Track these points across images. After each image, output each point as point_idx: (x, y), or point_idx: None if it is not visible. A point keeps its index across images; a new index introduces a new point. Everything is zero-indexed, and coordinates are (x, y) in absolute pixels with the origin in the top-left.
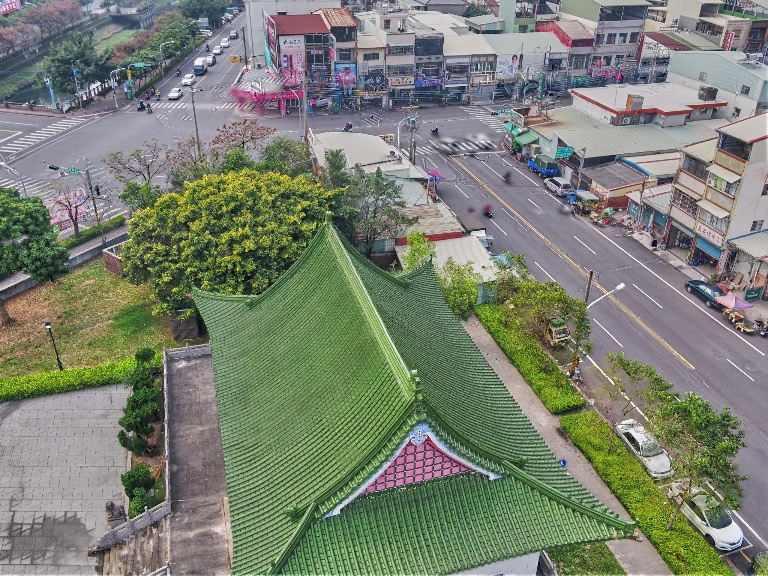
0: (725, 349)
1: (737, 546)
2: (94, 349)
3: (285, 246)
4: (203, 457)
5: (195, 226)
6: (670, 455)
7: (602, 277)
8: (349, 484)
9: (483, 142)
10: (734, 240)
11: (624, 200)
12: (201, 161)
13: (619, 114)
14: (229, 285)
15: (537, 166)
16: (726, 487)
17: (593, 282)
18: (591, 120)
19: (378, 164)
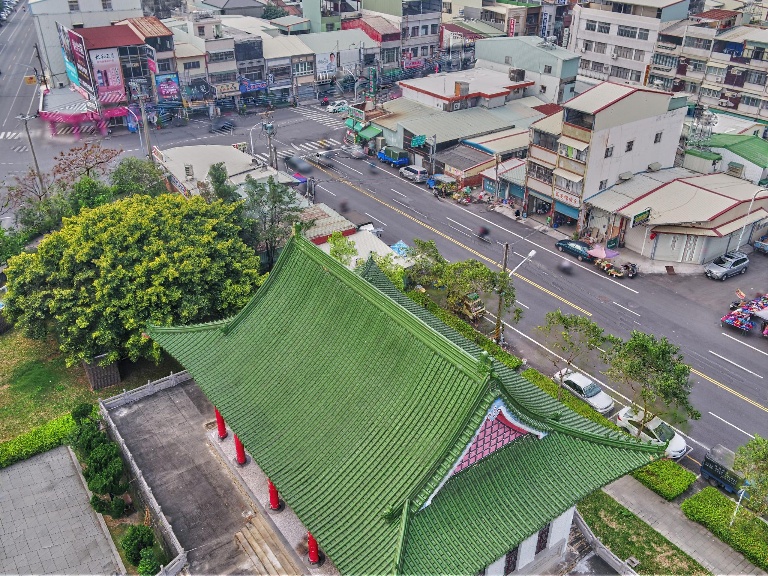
0: (608, 294)
1: (684, 452)
2: (2, 420)
3: (206, 268)
4: (194, 500)
5: (104, 263)
6: (604, 392)
7: (486, 250)
8: (438, 473)
9: (326, 140)
10: (588, 200)
11: (477, 178)
12: (45, 195)
13: (450, 101)
14: (155, 319)
15: (388, 157)
16: (656, 407)
17: (509, 253)
18: (425, 109)
19: (244, 174)
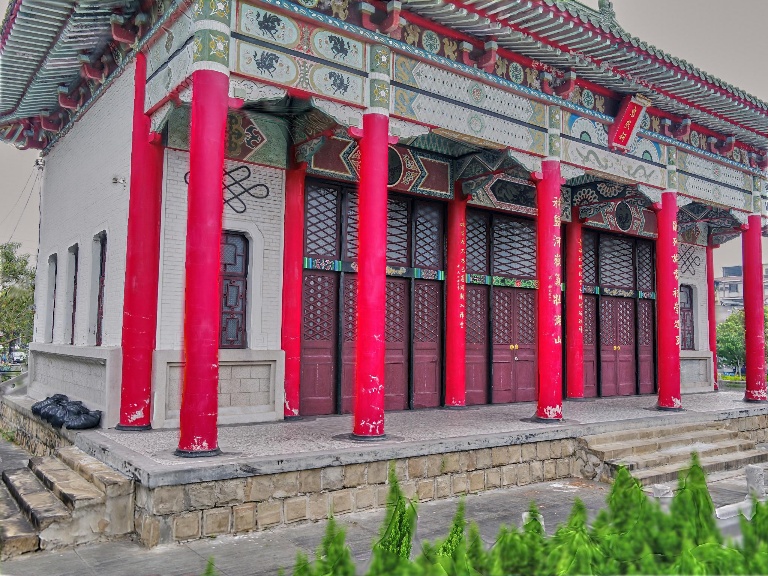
0: None
1: None
2: None
3: None
4: None
5: None
6: None
7: None
8: None
9: None
10: None
11: None
12: None
13: None
14: None
15: None
16: None
17: None
18: None
19: None
